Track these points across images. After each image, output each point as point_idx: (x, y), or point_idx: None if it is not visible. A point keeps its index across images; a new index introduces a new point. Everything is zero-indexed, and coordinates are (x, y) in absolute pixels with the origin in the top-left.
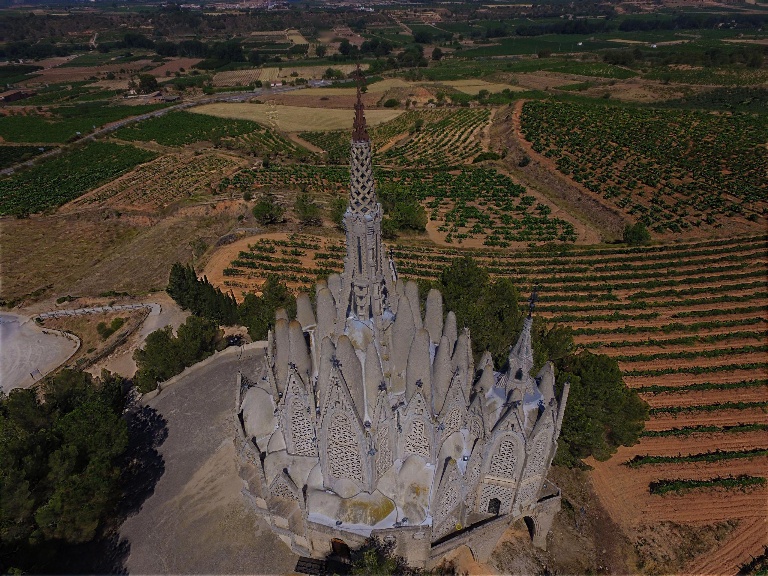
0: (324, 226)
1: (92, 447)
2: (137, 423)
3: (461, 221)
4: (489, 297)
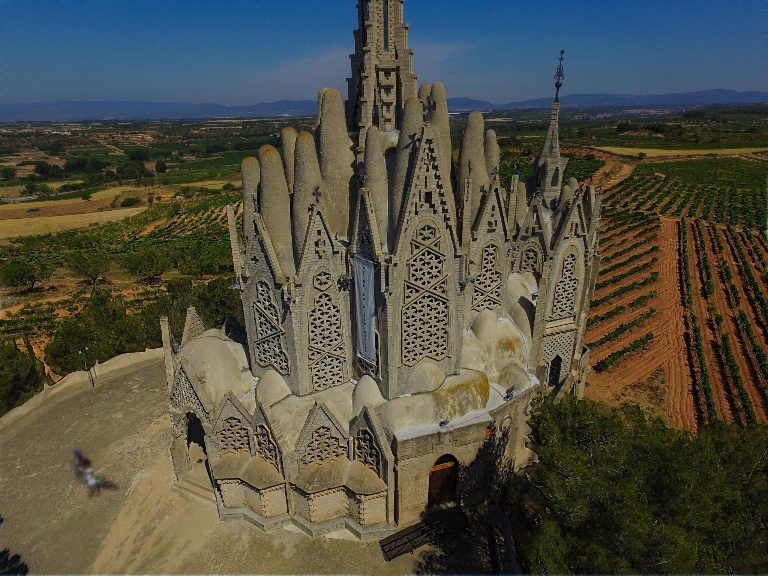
0: (116, 283)
1: None
2: None
3: None
4: None
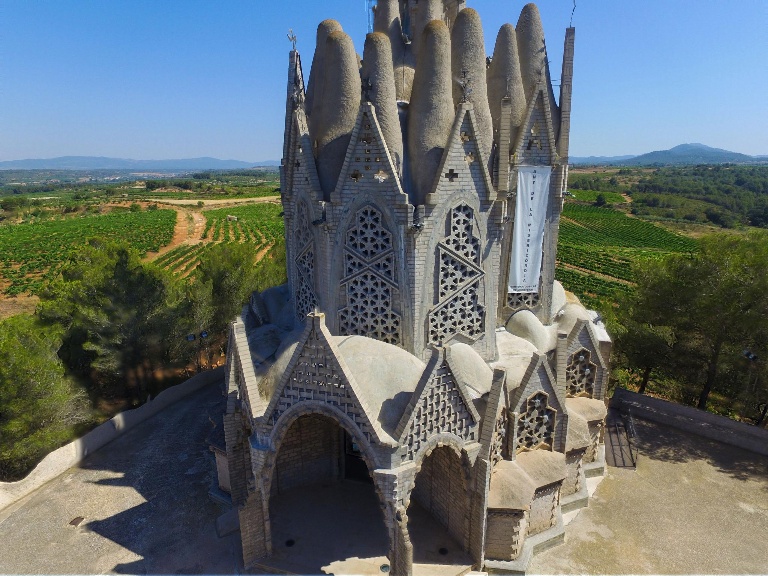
0: None
1: None
2: None
3: None
4: None
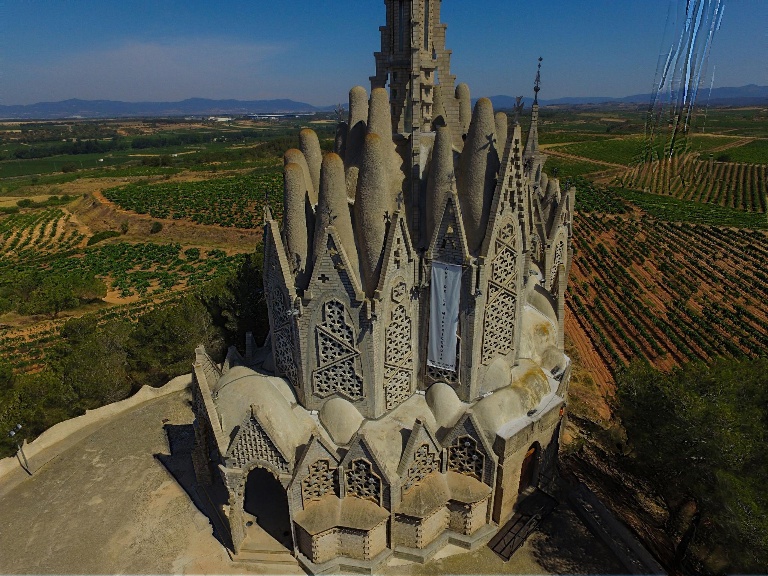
0: None
1: None
2: None
3: (141, 283)
4: None
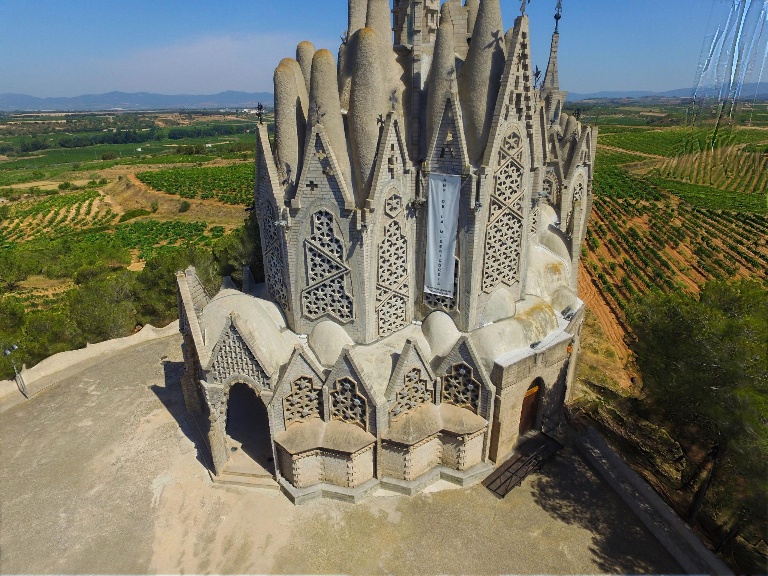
0: None
1: None
2: None
3: None
4: None
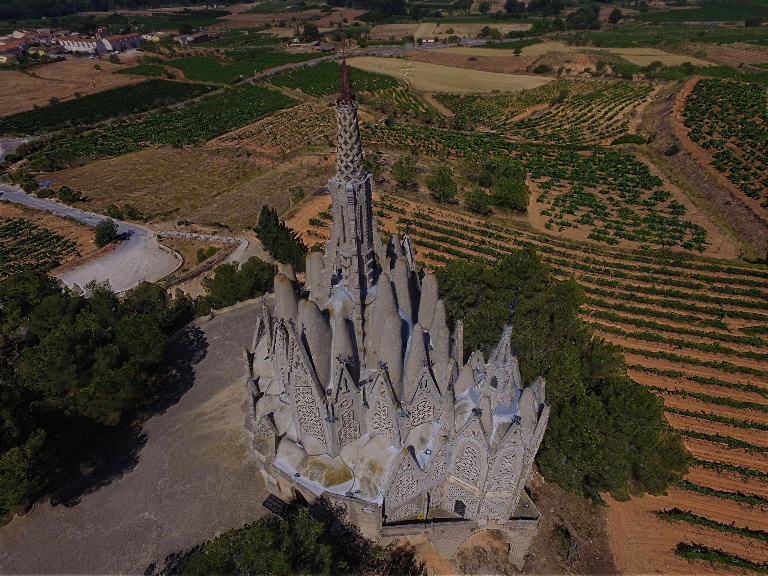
0: (419, 191)
1: (133, 351)
2: (186, 340)
3: (570, 207)
4: (548, 295)
